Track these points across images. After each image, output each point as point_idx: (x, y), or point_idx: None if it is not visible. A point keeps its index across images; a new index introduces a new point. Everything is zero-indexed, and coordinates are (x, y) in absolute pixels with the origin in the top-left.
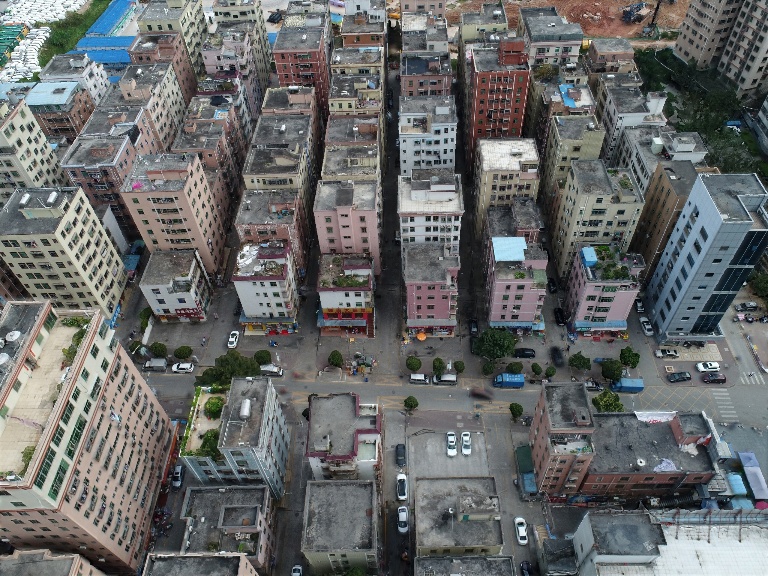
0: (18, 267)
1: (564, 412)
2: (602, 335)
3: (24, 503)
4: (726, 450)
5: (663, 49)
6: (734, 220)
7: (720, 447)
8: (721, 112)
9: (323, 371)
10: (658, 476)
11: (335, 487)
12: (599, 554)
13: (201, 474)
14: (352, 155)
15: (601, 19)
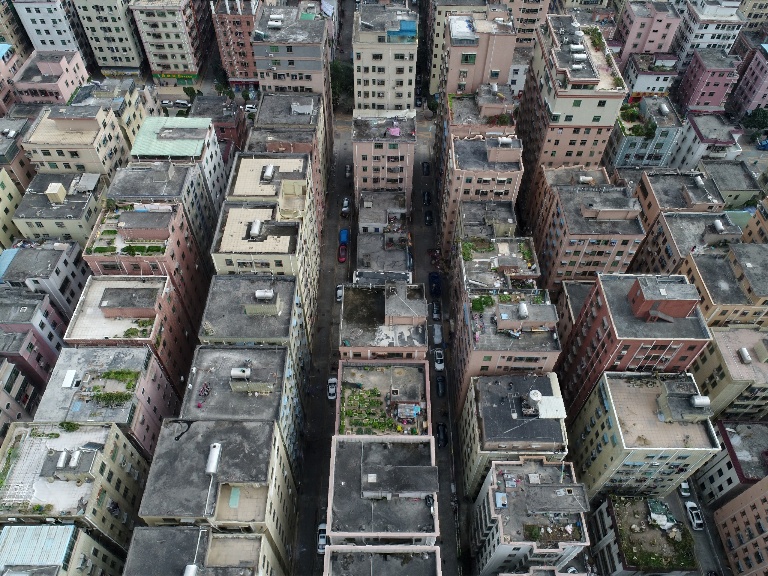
0: (441, 37)
1: None
2: None
3: (602, 117)
4: None
5: None
6: None
7: None
8: None
9: None
10: None
11: (717, 165)
12: None
13: (621, 159)
14: None
15: None
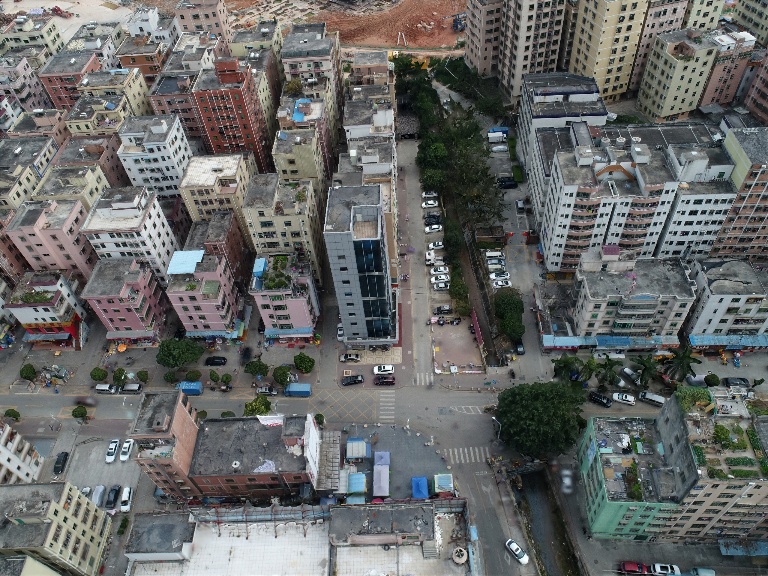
0: None
1: (152, 418)
2: (297, 341)
3: None
4: (361, 450)
5: (457, 58)
6: (335, 231)
7: (356, 447)
8: (497, 118)
9: (12, 384)
10: (257, 477)
11: None
12: (127, 552)
13: None
14: (62, 176)
15: (433, 28)
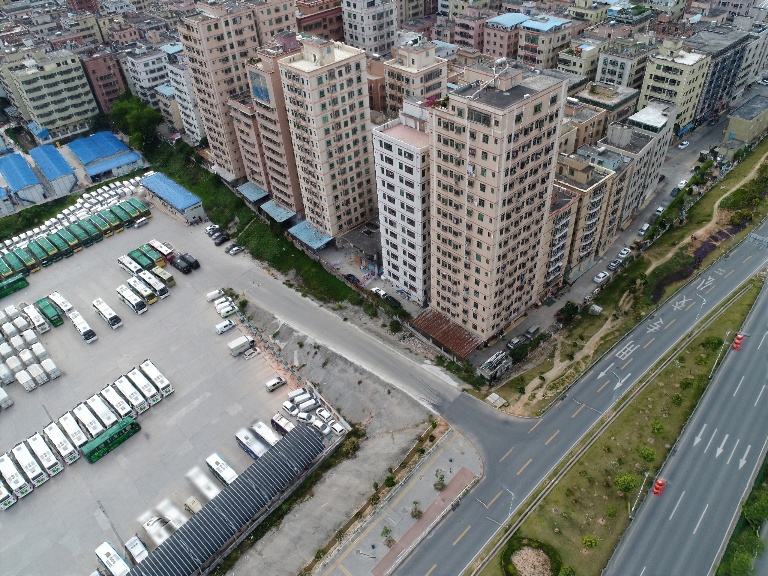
0: None
1: None
2: None
3: None
4: None
5: None
6: None
7: None
8: None
9: None
10: None
11: None
12: None
13: None
14: None
15: None
